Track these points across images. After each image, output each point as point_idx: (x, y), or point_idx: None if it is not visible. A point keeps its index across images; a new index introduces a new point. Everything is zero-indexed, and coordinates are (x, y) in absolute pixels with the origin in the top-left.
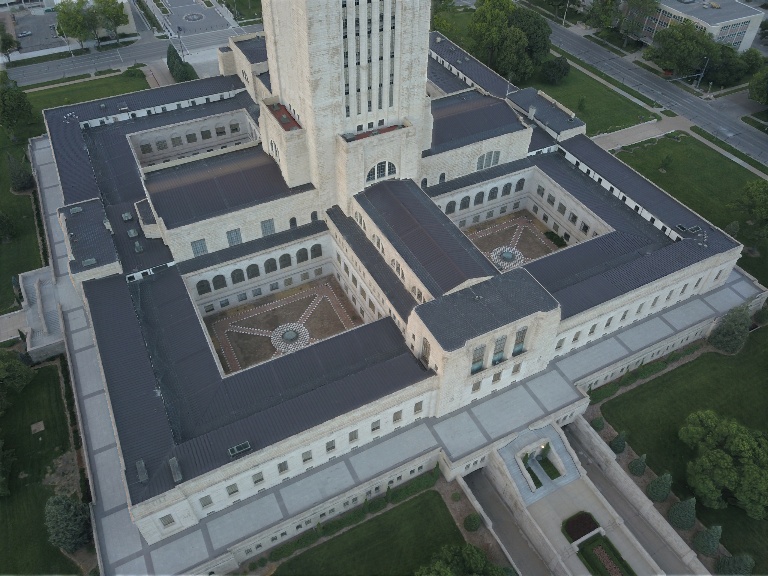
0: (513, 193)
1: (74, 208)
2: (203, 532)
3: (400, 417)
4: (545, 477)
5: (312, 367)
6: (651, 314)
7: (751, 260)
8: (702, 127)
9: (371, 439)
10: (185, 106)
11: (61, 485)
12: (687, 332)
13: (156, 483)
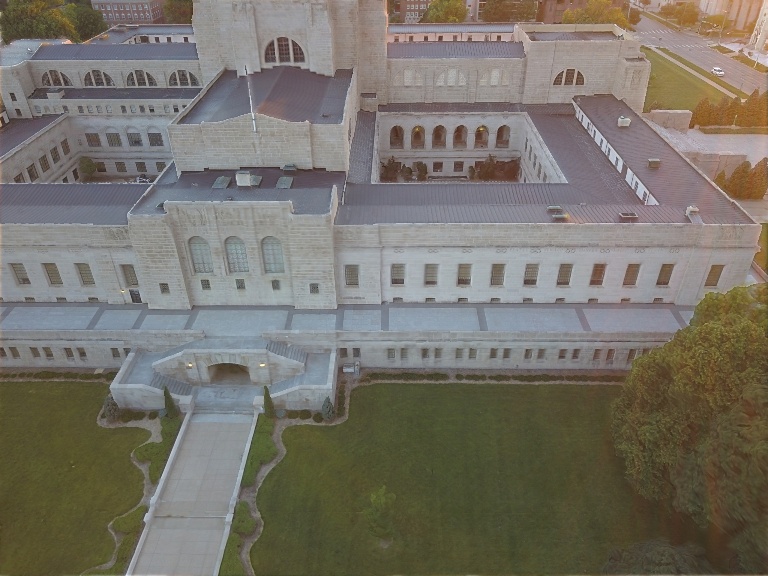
0: None
1: None
2: None
3: None
4: None
5: None
6: None
7: None
8: None
9: None
10: None
11: None
12: None
13: None
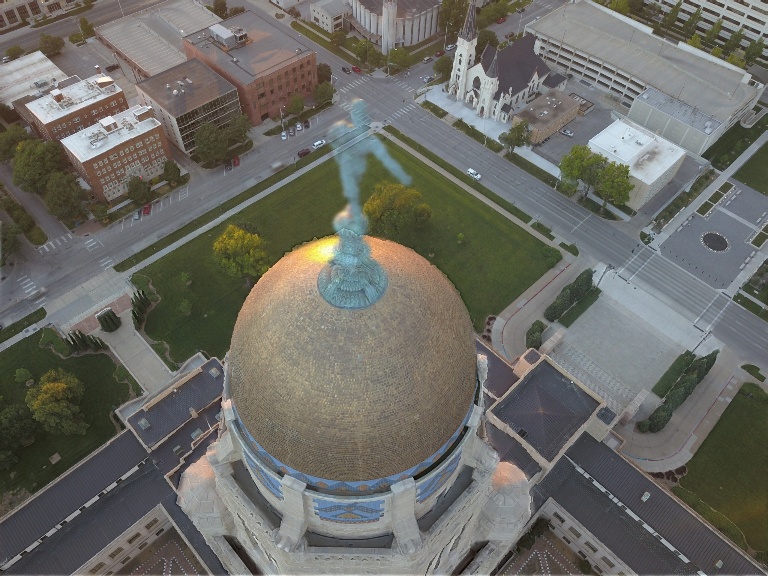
0: None
1: (213, 371)
2: None
3: None
4: None
5: None
6: None
7: None
8: None
9: None
10: None
11: (1, 507)
12: None
13: None
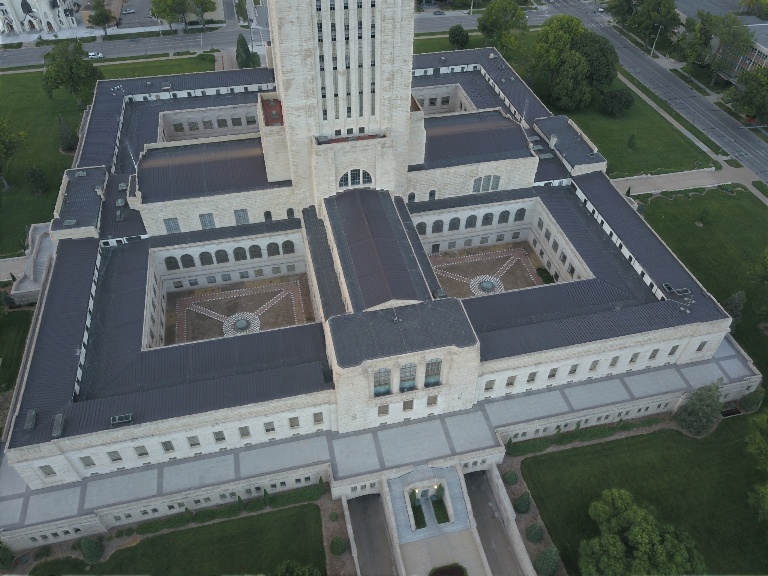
0: (512, 222)
1: (79, 172)
2: (81, 490)
3: (298, 424)
4: (432, 519)
5: (227, 357)
6: (611, 374)
7: (764, 338)
8: (767, 183)
9: (266, 439)
10: (224, 92)
11: None
12: (645, 402)
13: (38, 433)
